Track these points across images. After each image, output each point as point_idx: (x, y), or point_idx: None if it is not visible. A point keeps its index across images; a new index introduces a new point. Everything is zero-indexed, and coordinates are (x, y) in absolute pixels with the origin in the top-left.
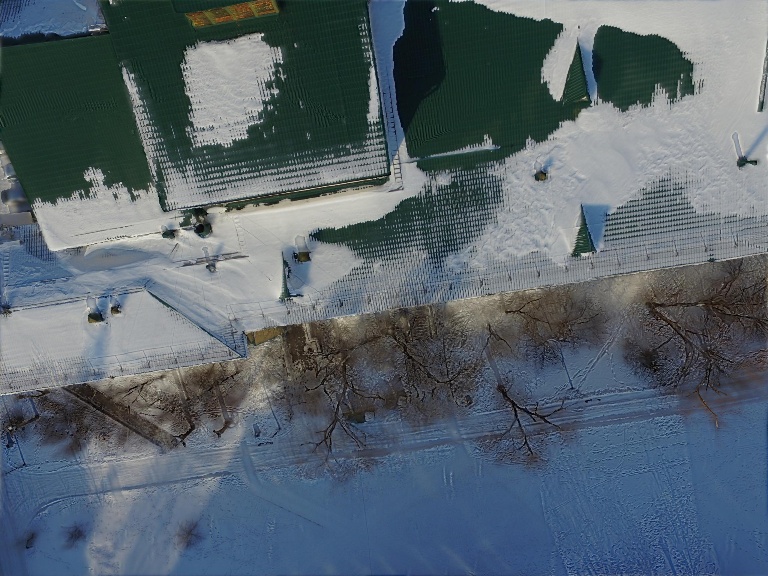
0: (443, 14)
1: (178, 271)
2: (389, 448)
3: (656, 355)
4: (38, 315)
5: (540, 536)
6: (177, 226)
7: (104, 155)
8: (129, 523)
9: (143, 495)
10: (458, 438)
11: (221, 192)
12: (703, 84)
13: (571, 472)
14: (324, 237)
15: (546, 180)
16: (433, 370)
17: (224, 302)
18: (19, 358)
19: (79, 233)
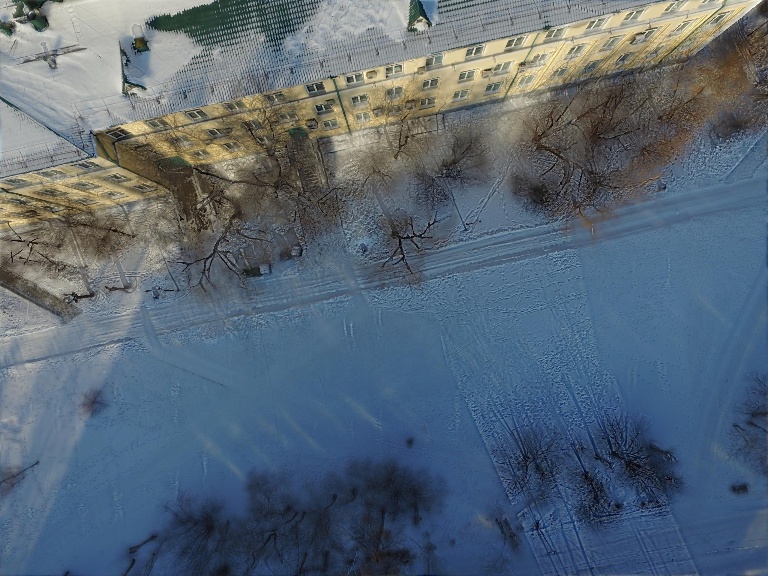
0: None
1: (19, 69)
2: (288, 303)
3: (545, 189)
4: None
5: (443, 381)
6: (10, 17)
7: None
8: (34, 396)
9: (46, 367)
10: (356, 288)
11: None
12: None
13: (470, 314)
14: (161, 25)
15: None
16: (327, 222)
17: (68, 100)
18: None
19: None
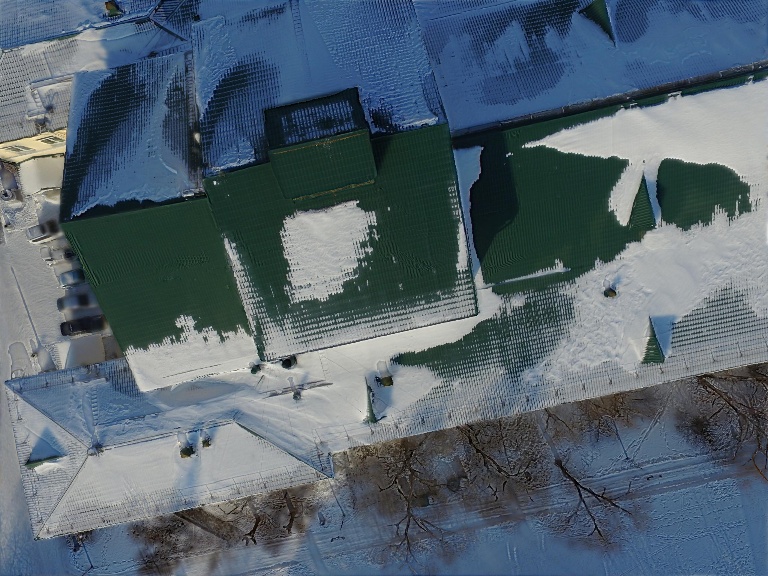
0: (517, 158)
1: (265, 401)
2: (453, 528)
3: (707, 422)
4: (130, 452)
5: None
6: None
7: (195, 303)
8: None
9: None
10: (519, 514)
11: (317, 341)
12: (760, 202)
13: (632, 540)
14: (404, 360)
15: (615, 296)
16: (491, 448)
17: (310, 427)
18: (111, 493)
19: (170, 374)
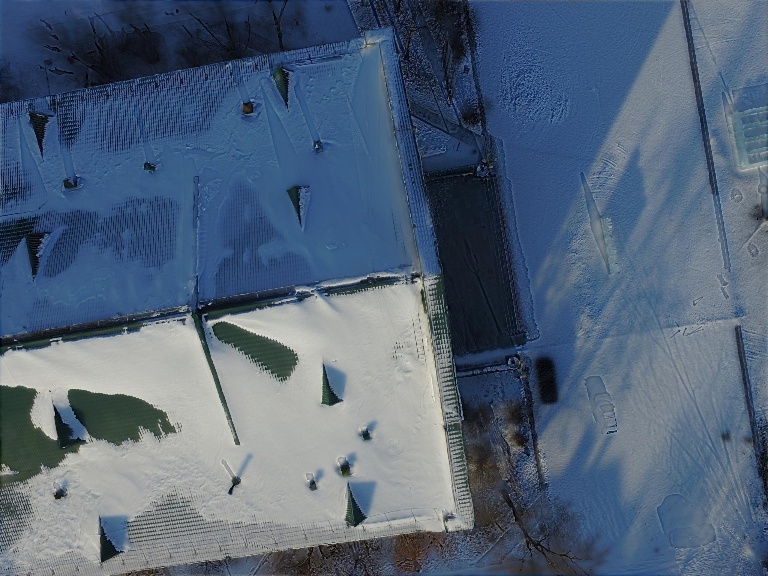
0: None
1: None
2: None
3: None
4: None
5: None
6: None
7: None
8: None
9: None
10: None
11: None
12: (181, 425)
13: None
14: None
15: (67, 496)
16: None
17: None
18: None
19: None
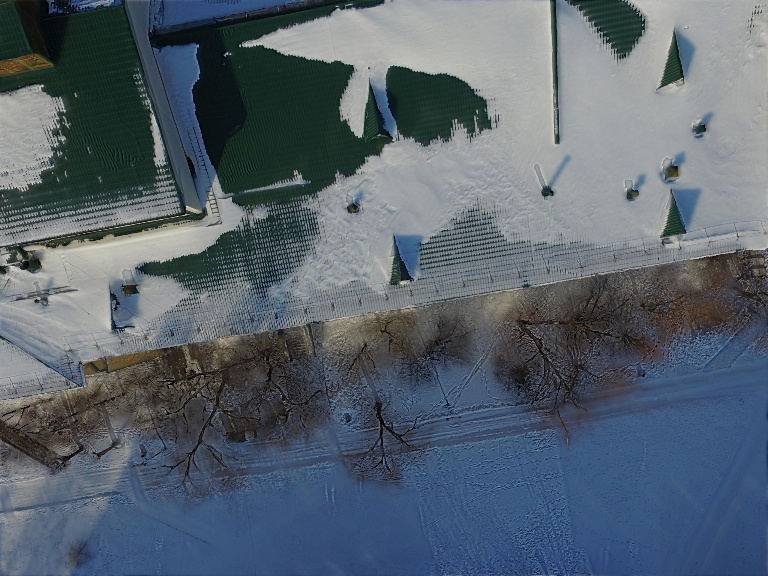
0: (236, 58)
1: (11, 305)
2: (272, 466)
3: (527, 371)
4: None
5: (420, 550)
6: (4, 263)
7: None
8: (22, 543)
9: (35, 515)
10: (339, 455)
11: (24, 233)
12: (499, 119)
13: (448, 487)
14: (150, 270)
15: (359, 212)
16: (313, 389)
17: (58, 334)
18: None
19: None
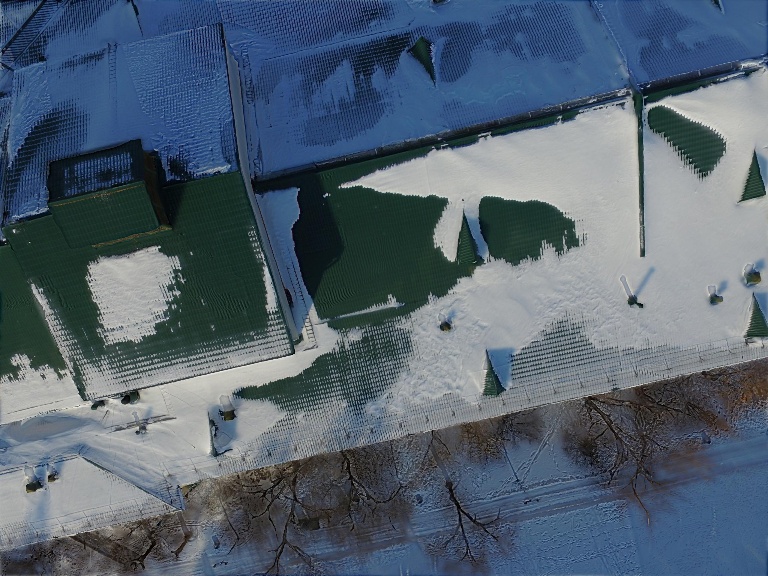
0: (335, 198)
1: (110, 436)
2: (346, 550)
3: (594, 444)
4: None
5: None
6: None
7: None
8: None
9: None
10: (412, 536)
11: (137, 381)
12: (586, 237)
13: (523, 562)
14: (247, 394)
15: (451, 329)
16: (383, 471)
17: (157, 460)
18: None
19: (12, 411)
